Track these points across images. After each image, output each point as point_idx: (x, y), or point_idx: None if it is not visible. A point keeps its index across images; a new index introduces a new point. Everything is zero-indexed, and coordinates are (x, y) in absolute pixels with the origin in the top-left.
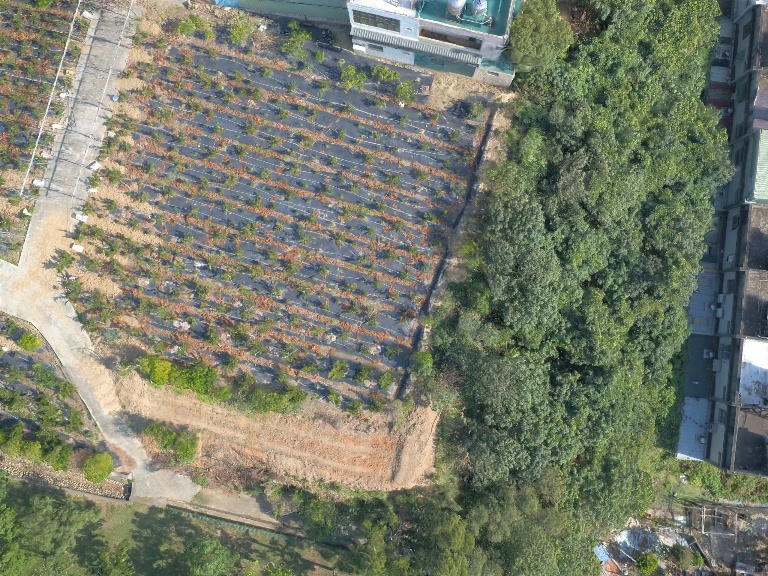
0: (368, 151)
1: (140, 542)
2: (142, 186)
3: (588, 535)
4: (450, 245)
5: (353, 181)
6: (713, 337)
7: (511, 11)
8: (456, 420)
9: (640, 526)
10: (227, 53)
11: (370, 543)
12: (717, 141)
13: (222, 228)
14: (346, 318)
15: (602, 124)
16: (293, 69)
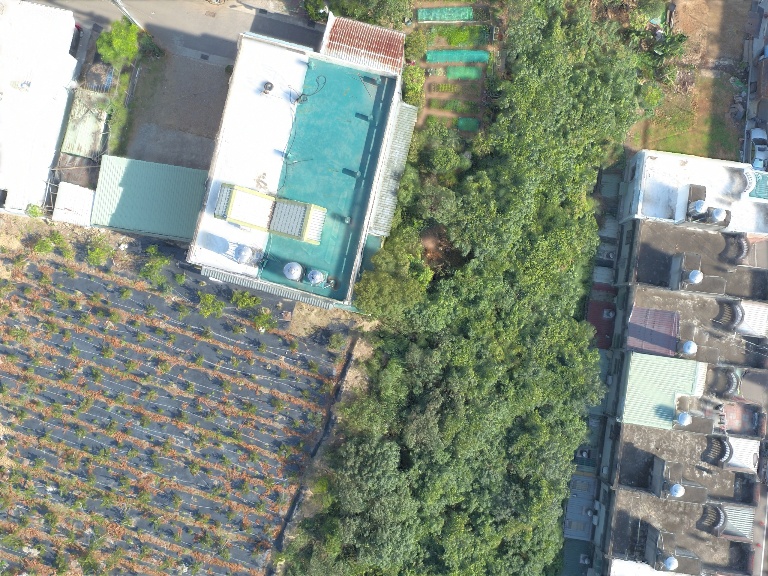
0: (227, 377)
1: None
2: None
3: None
4: (304, 481)
5: (210, 408)
6: (590, 542)
7: (352, 276)
8: None
9: None
10: (87, 271)
11: None
12: (588, 361)
13: (76, 451)
14: (198, 548)
15: (462, 359)
16: (153, 289)
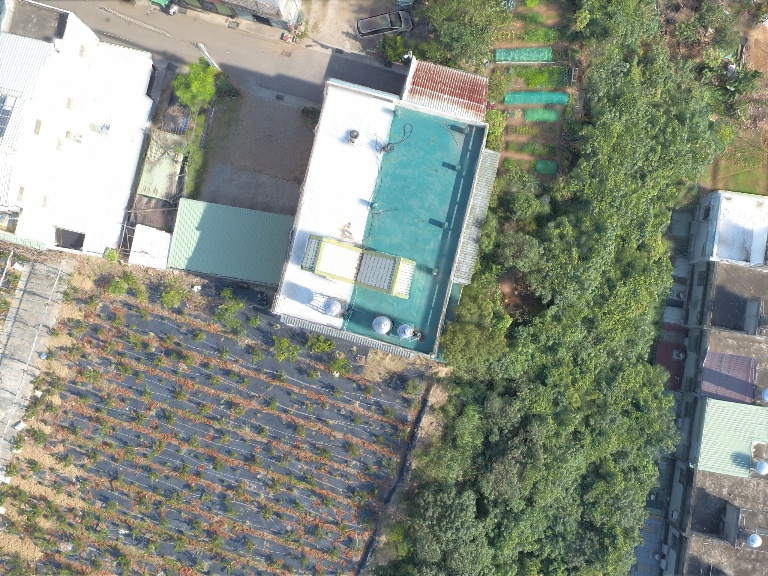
0: (300, 421)
1: None
2: (68, 448)
3: None
4: (379, 528)
5: (283, 453)
6: None
7: (440, 329)
8: None
9: None
10: (160, 312)
11: None
12: (663, 407)
13: (148, 494)
14: None
15: (540, 407)
16: (227, 332)
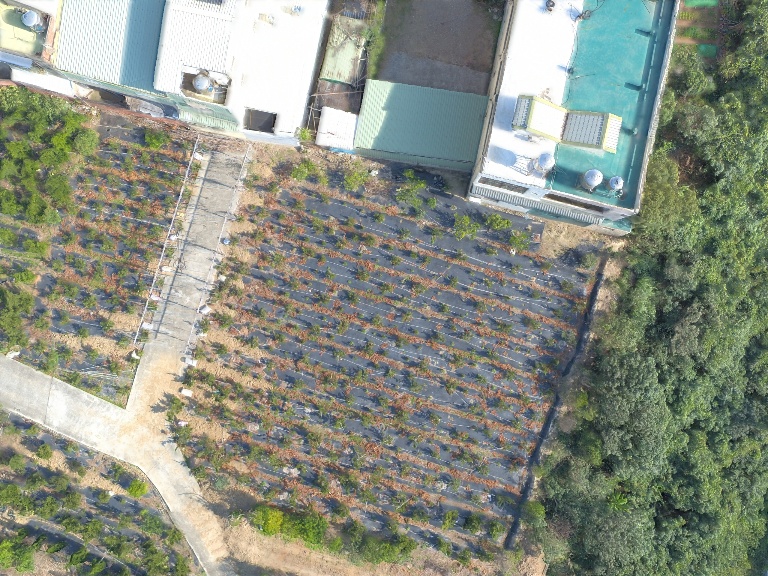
0: (479, 298)
1: None
2: (252, 330)
3: None
4: (563, 397)
5: (465, 329)
6: None
7: (642, 185)
8: (565, 569)
9: None
10: (338, 197)
11: None
12: None
13: (332, 373)
14: (457, 466)
15: (713, 277)
16: (404, 214)
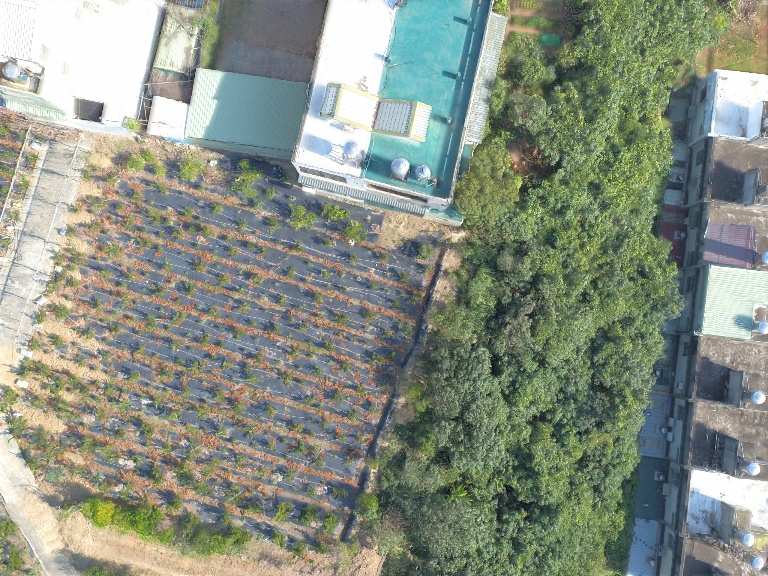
0: (317, 289)
1: None
2: (89, 321)
3: None
4: (397, 388)
5: (302, 320)
6: (664, 459)
7: (455, 174)
8: (402, 561)
9: None
10: (177, 187)
11: None
12: (667, 275)
13: (169, 365)
14: (293, 458)
15: (550, 267)
16: (243, 205)
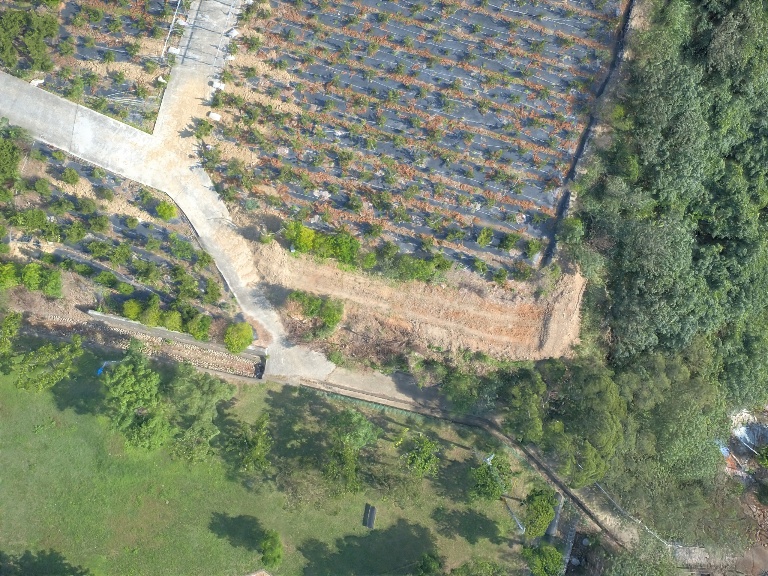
0: (510, 20)
1: (273, 422)
2: (280, 54)
3: (725, 417)
4: (598, 111)
5: (496, 49)
6: None
7: None
8: (602, 290)
9: (758, 423)
10: None
11: (524, 408)
12: None
13: (362, 97)
14: (490, 187)
15: None
16: None
